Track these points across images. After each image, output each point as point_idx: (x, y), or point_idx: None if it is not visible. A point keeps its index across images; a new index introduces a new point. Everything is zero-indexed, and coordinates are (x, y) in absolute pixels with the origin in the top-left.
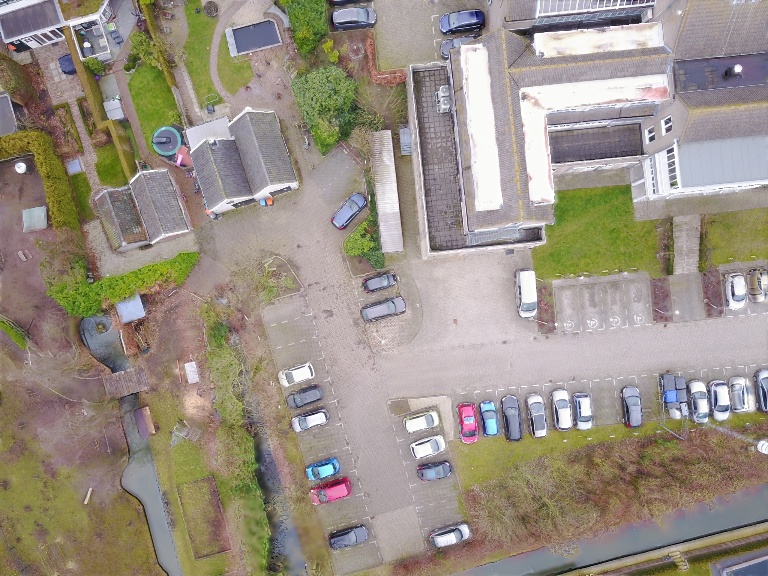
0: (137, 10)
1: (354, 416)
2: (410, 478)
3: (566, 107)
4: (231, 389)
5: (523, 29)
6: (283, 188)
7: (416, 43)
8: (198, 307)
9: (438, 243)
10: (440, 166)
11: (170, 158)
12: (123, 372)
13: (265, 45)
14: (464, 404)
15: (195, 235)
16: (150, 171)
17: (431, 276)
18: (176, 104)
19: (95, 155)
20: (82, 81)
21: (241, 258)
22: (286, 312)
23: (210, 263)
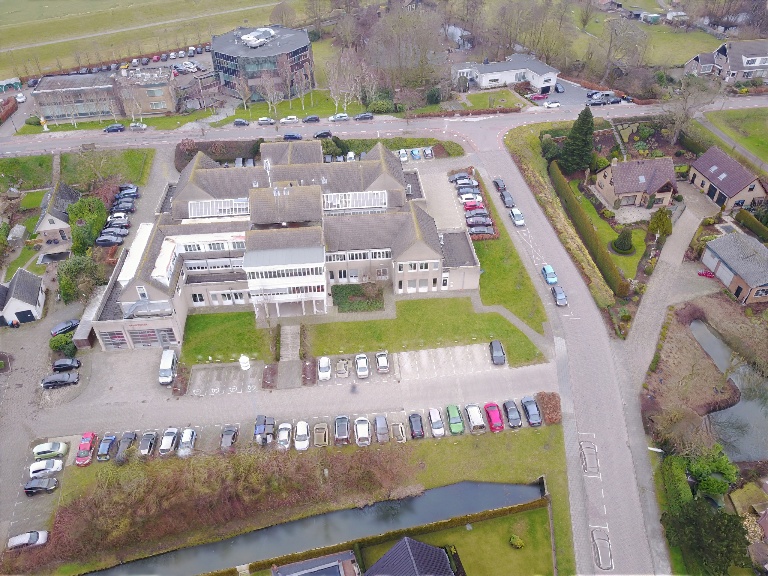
0: None
1: None
2: (19, 497)
3: (189, 242)
4: None
5: None
6: (26, 312)
7: None
8: None
9: None
10: None
11: None
12: None
13: (59, 260)
14: None
15: None
16: None
17: (105, 361)
18: None
19: None
20: None
21: None
22: None
23: None
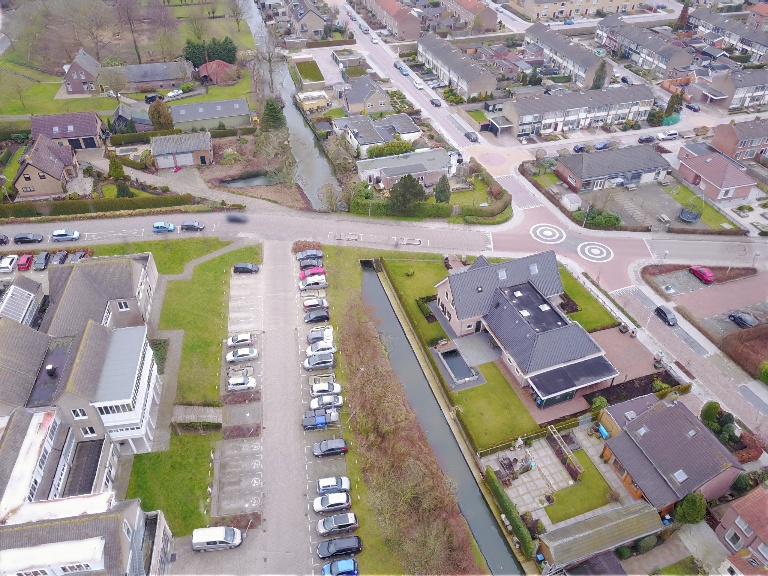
0: None
1: None
2: None
3: (29, 486)
4: None
5: None
6: None
7: None
8: None
9: None
10: None
11: None
12: None
13: None
14: None
15: None
16: None
17: None
18: None
19: None
20: None
21: None
22: None
23: None
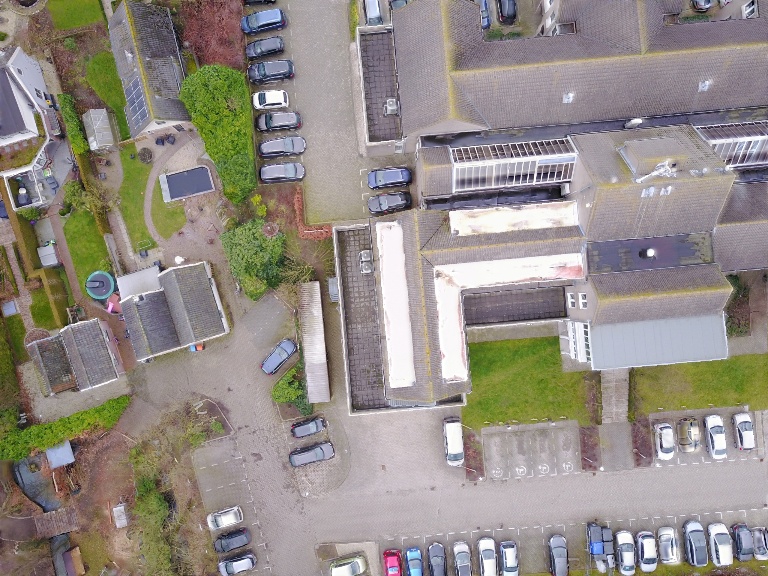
0: (72, 156)
1: (282, 560)
2: None
3: (480, 285)
4: (161, 530)
5: (443, 198)
6: None
7: (344, 197)
8: (129, 448)
9: (360, 402)
10: (363, 325)
11: (103, 301)
12: (54, 512)
13: (198, 191)
14: (390, 552)
15: (127, 377)
16: (79, 323)
17: (360, 422)
18: (108, 252)
19: (30, 297)
20: (15, 230)
21: (172, 400)
22: (216, 455)
23: (142, 405)
